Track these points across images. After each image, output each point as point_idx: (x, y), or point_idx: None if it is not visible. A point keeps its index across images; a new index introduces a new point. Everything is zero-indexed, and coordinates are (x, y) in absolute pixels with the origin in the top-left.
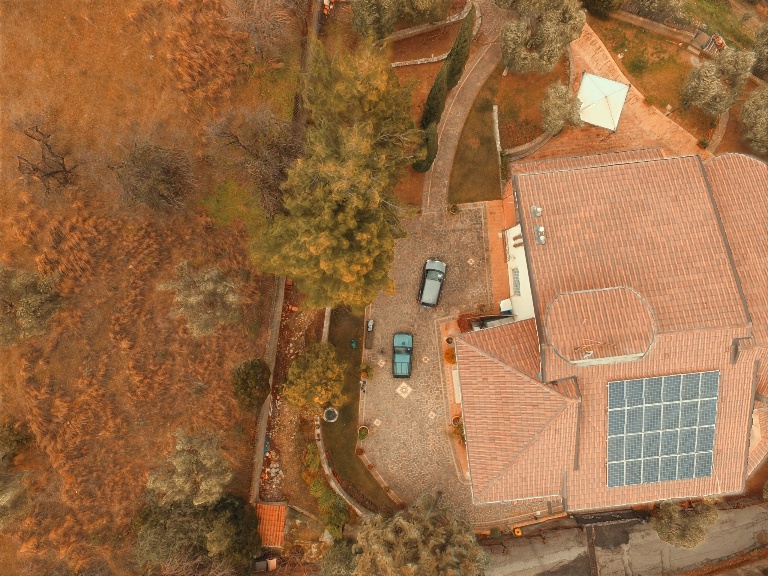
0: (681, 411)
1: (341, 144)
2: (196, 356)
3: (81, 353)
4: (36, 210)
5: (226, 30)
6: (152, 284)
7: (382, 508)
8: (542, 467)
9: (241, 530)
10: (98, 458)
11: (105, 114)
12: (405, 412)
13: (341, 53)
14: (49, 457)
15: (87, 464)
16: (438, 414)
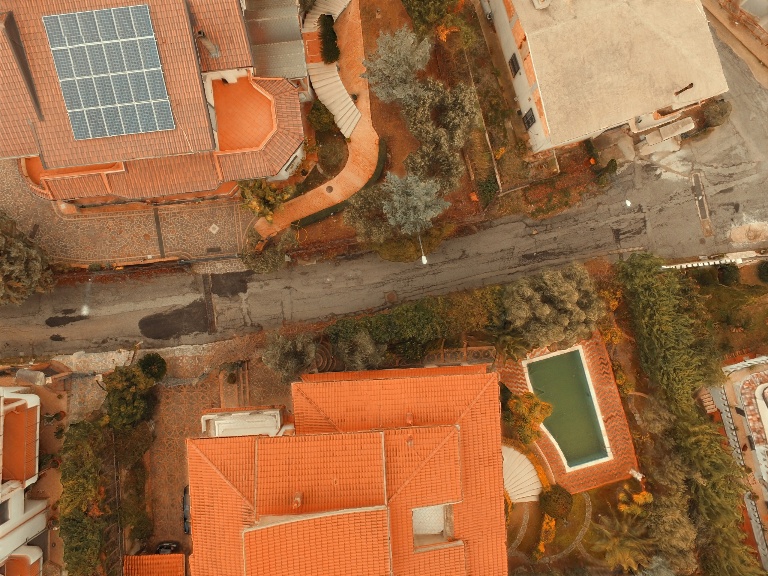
0: (123, 52)
1: None
2: None
3: None
4: None
5: None
6: None
7: None
8: (6, 116)
9: None
10: None
11: None
12: None
13: None
14: None
15: None
16: None
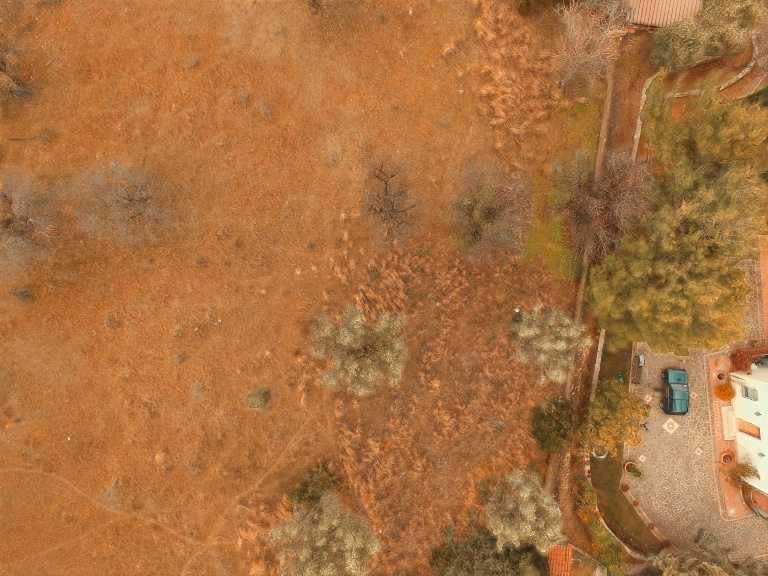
0: None
1: (702, 187)
2: (498, 395)
3: (389, 392)
4: (352, 247)
5: (533, 64)
6: (458, 322)
7: (646, 545)
8: None
9: (542, 571)
10: (402, 497)
11: (416, 150)
12: (671, 448)
13: (628, 86)
14: (361, 497)
15: (390, 503)
16: (705, 450)
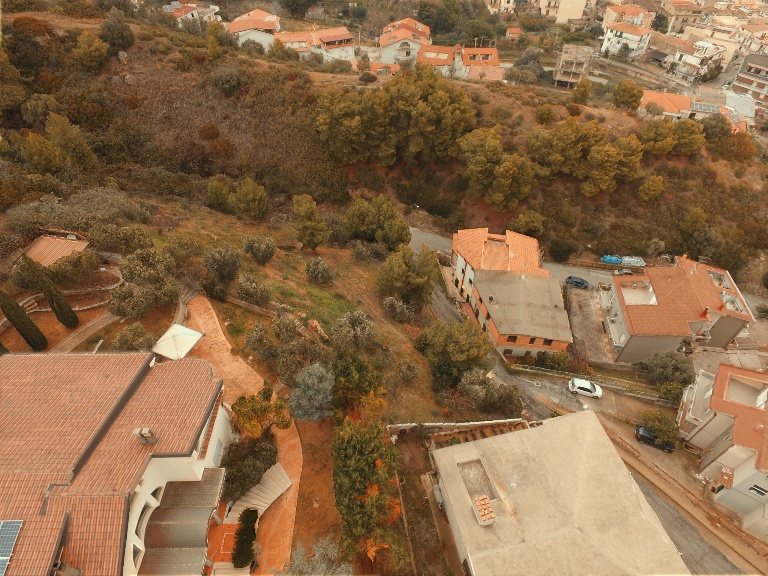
0: None
1: None
2: None
3: None
4: None
5: None
6: None
7: None
8: None
9: None
10: None
11: None
12: None
13: None
14: None
15: None
16: None
